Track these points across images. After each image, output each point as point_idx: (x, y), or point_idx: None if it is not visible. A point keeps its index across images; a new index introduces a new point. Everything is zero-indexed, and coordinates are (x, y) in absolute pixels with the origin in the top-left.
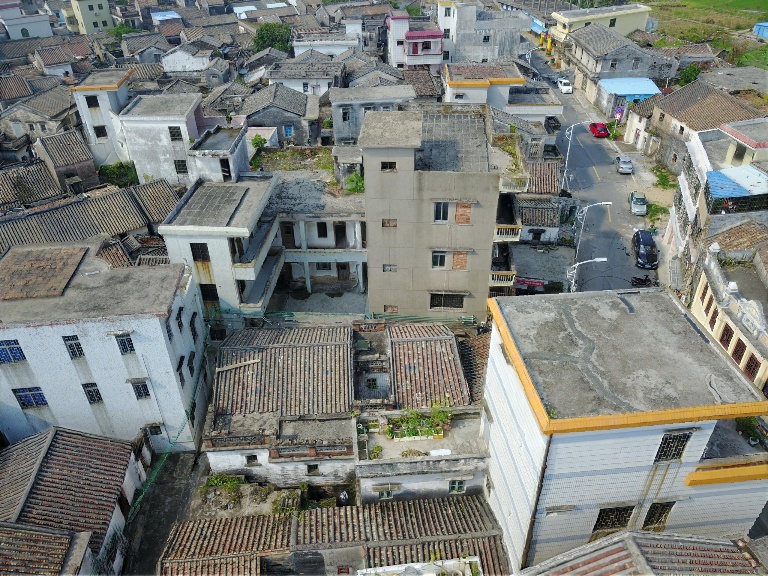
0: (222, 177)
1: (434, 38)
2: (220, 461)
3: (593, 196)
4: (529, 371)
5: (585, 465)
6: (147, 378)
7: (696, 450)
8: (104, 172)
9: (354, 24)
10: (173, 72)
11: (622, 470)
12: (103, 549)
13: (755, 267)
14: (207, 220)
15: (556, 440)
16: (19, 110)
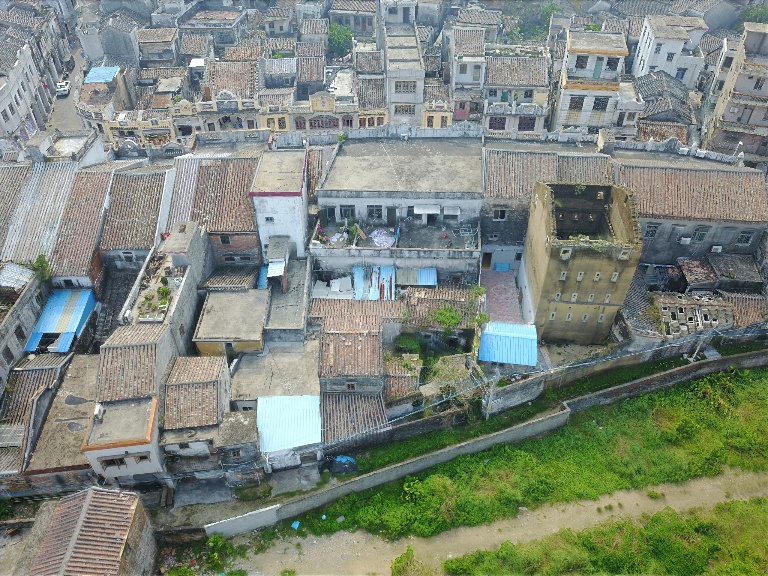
0: None
1: None
2: None
3: None
4: None
5: None
6: None
7: None
8: None
9: None
10: None
11: None
12: None
13: None
14: None
15: None
16: None
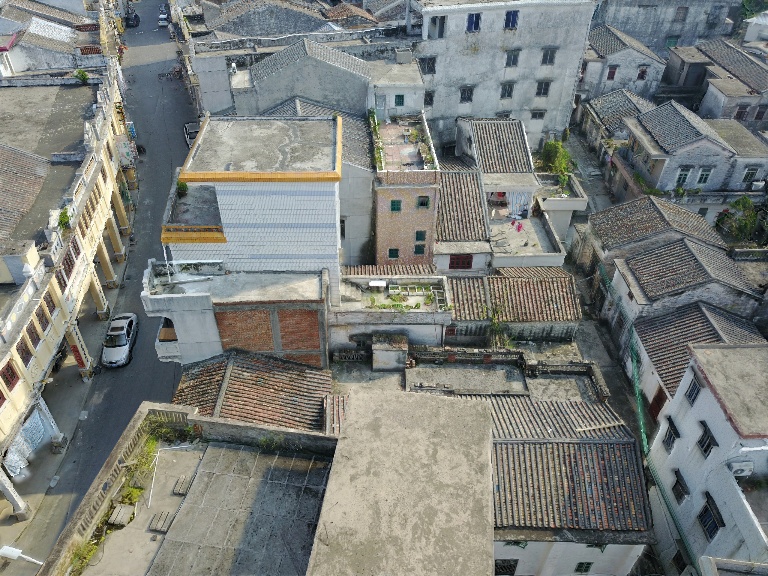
0: None
1: None
2: None
3: None
4: None
5: None
6: None
7: None
8: None
9: None
10: None
11: None
12: None
13: None
14: None
15: None
16: None
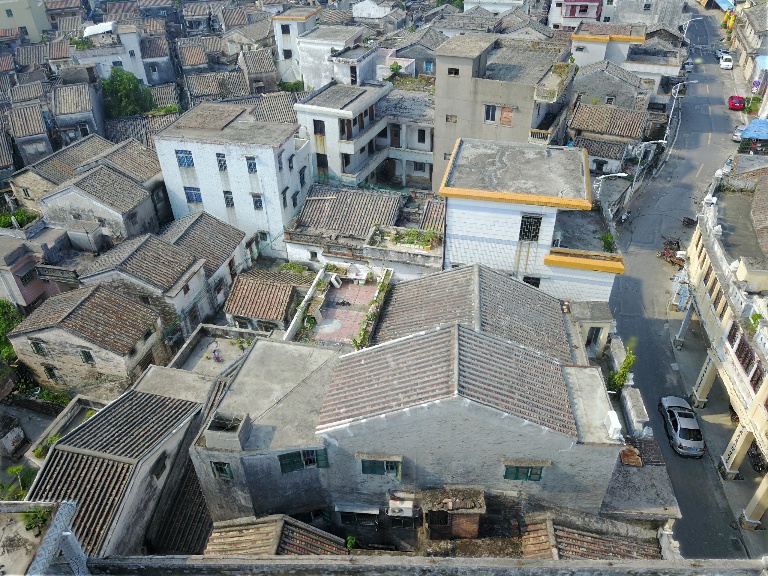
0: (350, 81)
1: (591, 2)
2: (294, 253)
3: (693, 155)
4: (454, 171)
5: (473, 231)
6: (262, 194)
7: (547, 235)
8: (284, 86)
9: None
10: (359, 18)
11: (498, 241)
12: (213, 279)
13: (754, 195)
14: (328, 105)
15: (451, 205)
16: (235, 33)
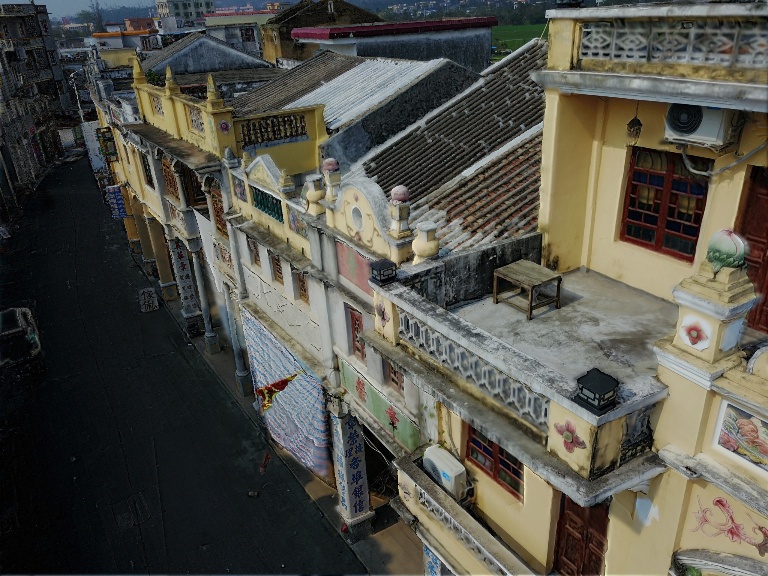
0: None
1: None
2: None
3: None
4: None
5: None
6: None
7: None
8: None
9: (91, 38)
10: None
11: None
12: None
13: None
14: None
15: None
16: None
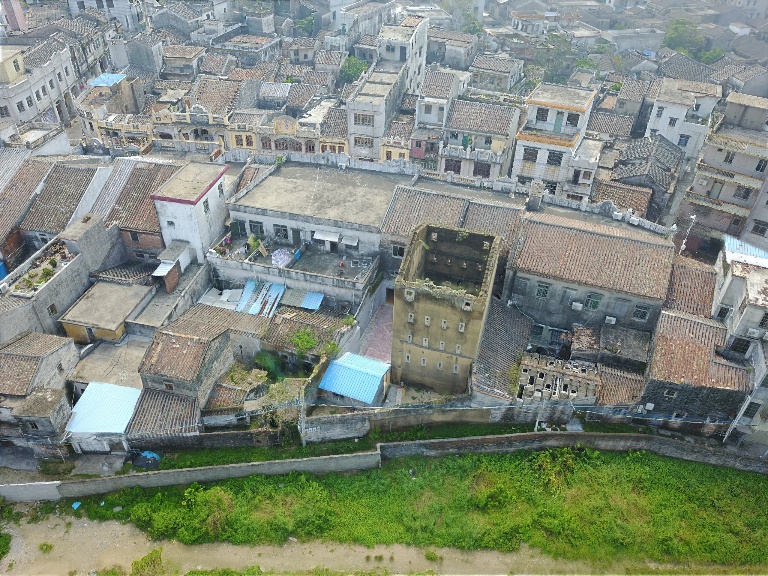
0: None
1: None
2: None
3: None
4: None
5: None
6: None
7: None
8: None
9: None
10: None
11: None
12: None
13: None
14: None
15: None
16: None
